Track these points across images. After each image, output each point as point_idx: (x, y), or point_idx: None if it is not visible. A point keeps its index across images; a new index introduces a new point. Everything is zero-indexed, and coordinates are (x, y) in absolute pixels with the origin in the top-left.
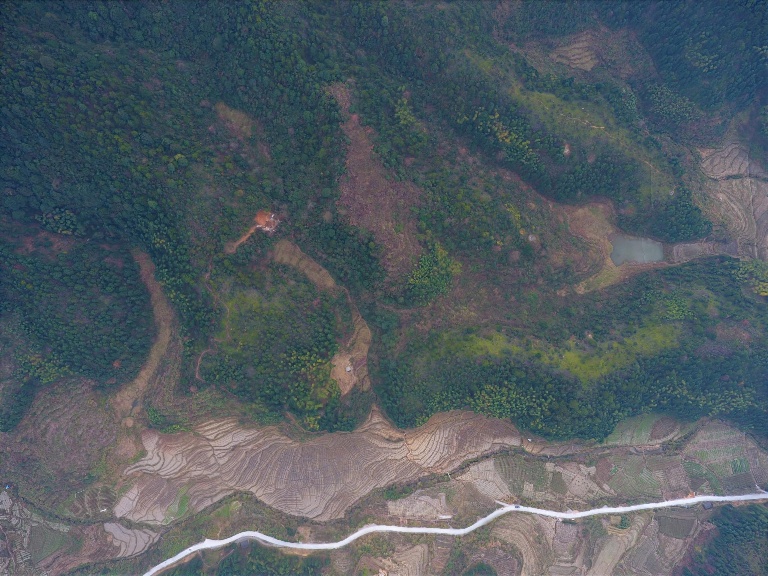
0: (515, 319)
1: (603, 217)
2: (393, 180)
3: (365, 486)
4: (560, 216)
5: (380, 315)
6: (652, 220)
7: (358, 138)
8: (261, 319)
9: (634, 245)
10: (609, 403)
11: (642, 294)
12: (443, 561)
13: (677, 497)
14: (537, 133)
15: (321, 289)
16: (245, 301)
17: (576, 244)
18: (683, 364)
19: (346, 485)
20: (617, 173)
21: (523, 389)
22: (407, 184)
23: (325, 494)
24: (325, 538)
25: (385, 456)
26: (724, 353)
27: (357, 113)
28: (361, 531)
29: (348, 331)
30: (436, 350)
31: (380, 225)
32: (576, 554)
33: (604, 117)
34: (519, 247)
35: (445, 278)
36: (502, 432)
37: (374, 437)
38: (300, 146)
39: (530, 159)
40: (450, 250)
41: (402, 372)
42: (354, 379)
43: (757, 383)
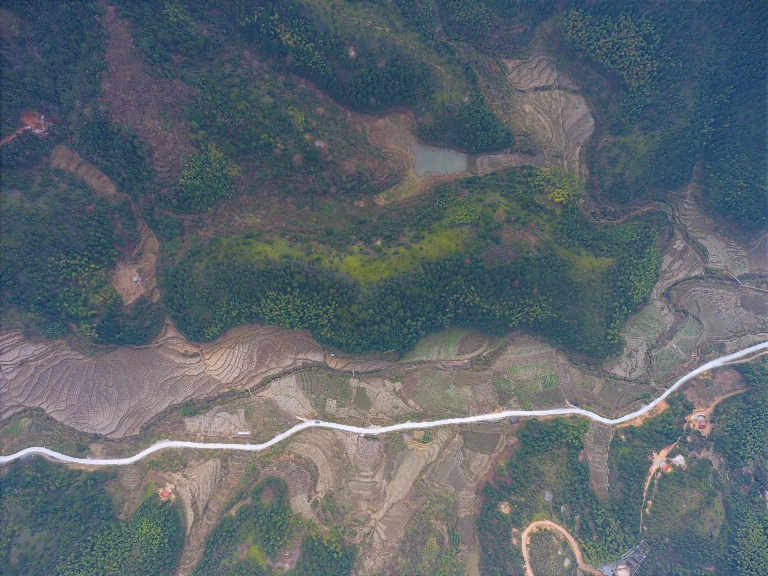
0: (301, 226)
1: (405, 128)
2: (157, 76)
3: (161, 402)
4: (358, 125)
5: (161, 221)
6: (450, 128)
7: (117, 31)
8: (21, 219)
9: (437, 156)
10: (394, 309)
11: (436, 201)
12: (238, 476)
13: (484, 412)
14: (319, 34)
15: (100, 195)
16: (4, 200)
17: (372, 153)
18: (467, 267)
19: (141, 401)
20: (410, 79)
21: (308, 296)
22: (175, 82)
23: (119, 410)
24: (116, 454)
25: (182, 372)
26: (511, 257)
27: (115, 5)
28: (154, 447)
29: (129, 238)
30: (212, 254)
31: (145, 122)
32: (377, 469)
33: (389, 18)
34: (303, 151)
35: (223, 181)
36: (305, 348)
37: (170, 352)
38: (68, 45)
39: (317, 63)
40: (231, 154)
41: (180, 278)
42: (141, 290)
43: (554, 291)
